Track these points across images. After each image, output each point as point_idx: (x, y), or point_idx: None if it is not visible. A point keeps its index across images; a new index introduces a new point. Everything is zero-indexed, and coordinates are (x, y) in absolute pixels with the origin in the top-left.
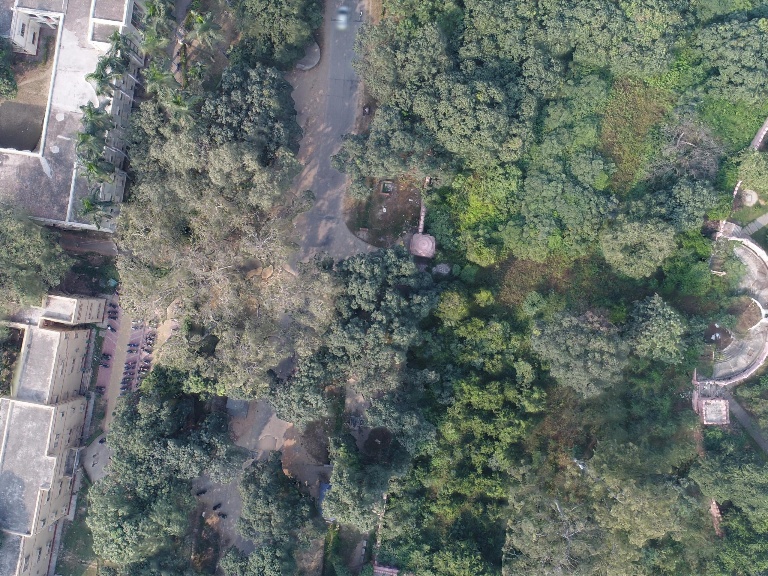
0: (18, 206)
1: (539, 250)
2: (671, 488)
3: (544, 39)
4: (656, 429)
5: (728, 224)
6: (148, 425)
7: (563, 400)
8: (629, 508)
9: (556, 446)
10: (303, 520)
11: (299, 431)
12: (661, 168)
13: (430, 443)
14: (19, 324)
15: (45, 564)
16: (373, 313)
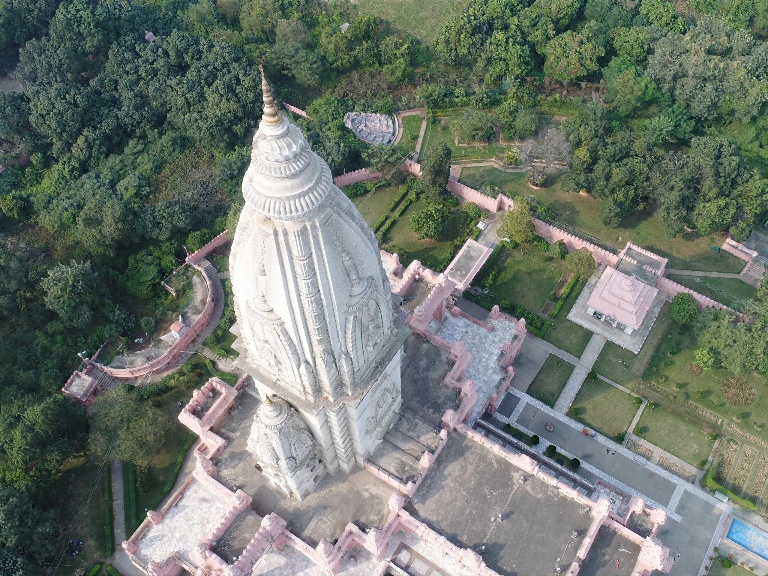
0: None
1: (52, 219)
2: None
3: (148, 94)
4: (19, 374)
5: (205, 261)
6: None
7: None
8: None
9: None
10: None
11: None
12: None
13: None
14: None
15: None
16: None
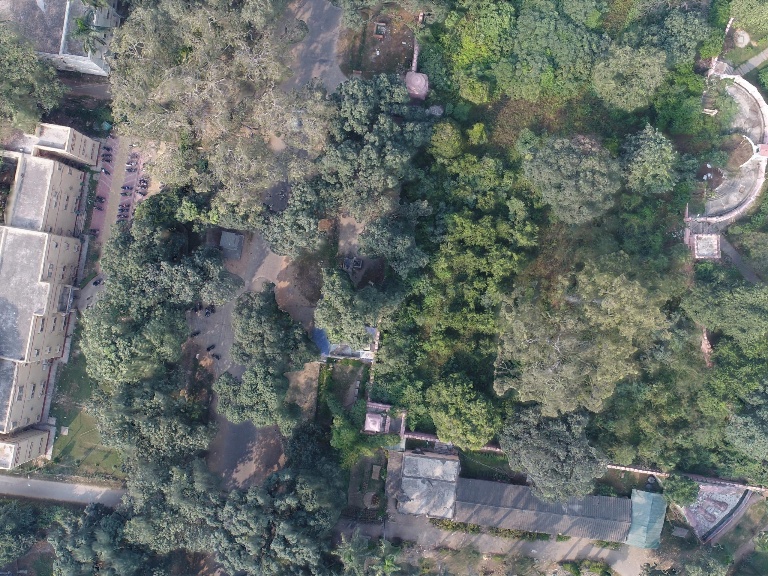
0: (11, 21)
1: (532, 88)
2: None
3: None
4: (648, 262)
5: (720, 64)
6: (141, 248)
7: (555, 240)
8: (619, 296)
9: (548, 285)
10: (296, 342)
11: (292, 259)
12: (653, 6)
13: (423, 280)
14: (13, 152)
15: (39, 404)
16: (366, 135)
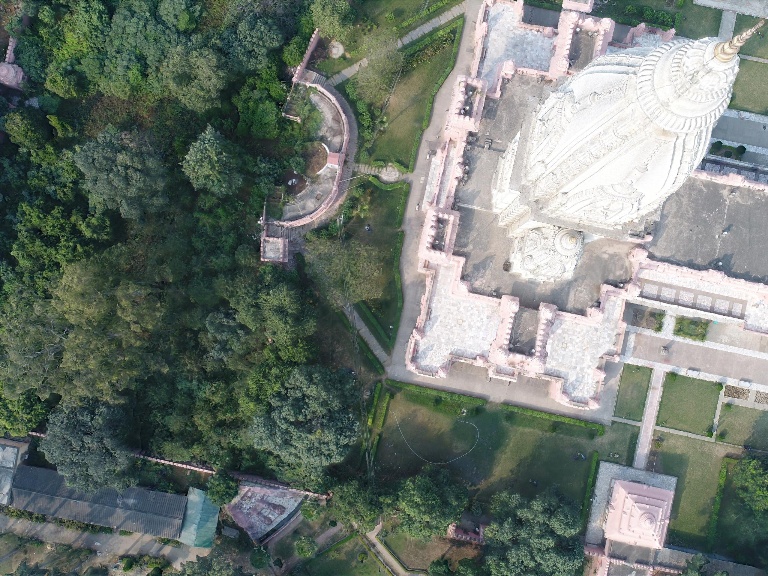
0: None
1: (119, 85)
2: (221, 320)
3: None
4: (211, 262)
5: (309, 72)
6: None
7: (140, 236)
8: None
9: None
10: None
11: None
12: None
13: None
14: None
15: None
16: None
